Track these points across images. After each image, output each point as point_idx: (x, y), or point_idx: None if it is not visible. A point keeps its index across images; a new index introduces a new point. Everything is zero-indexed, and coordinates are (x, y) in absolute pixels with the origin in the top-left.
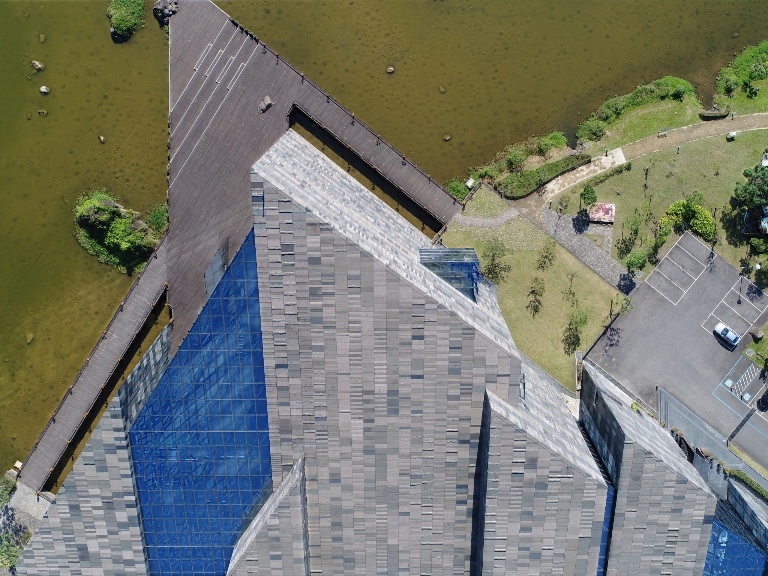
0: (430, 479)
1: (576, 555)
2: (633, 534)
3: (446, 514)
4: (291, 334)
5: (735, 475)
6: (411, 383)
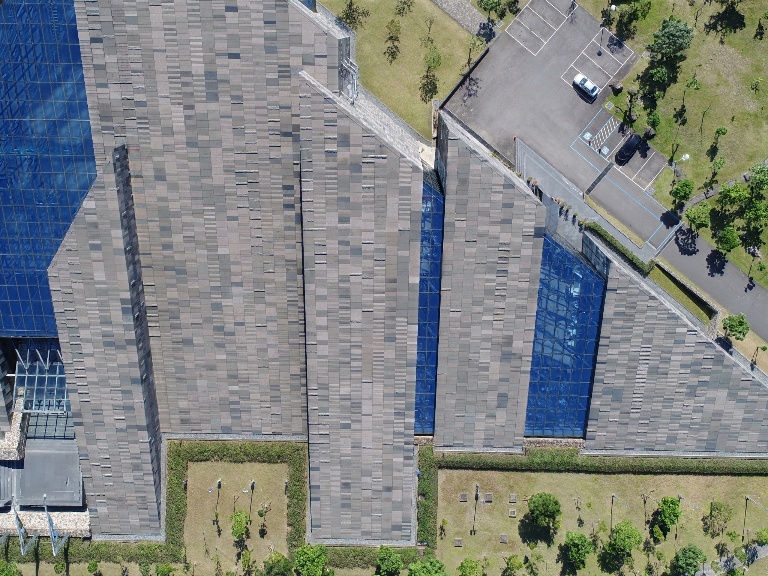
0: (256, 178)
1: (397, 251)
2: (464, 248)
3: (275, 220)
4: (103, 2)
5: (590, 227)
6: (228, 63)
